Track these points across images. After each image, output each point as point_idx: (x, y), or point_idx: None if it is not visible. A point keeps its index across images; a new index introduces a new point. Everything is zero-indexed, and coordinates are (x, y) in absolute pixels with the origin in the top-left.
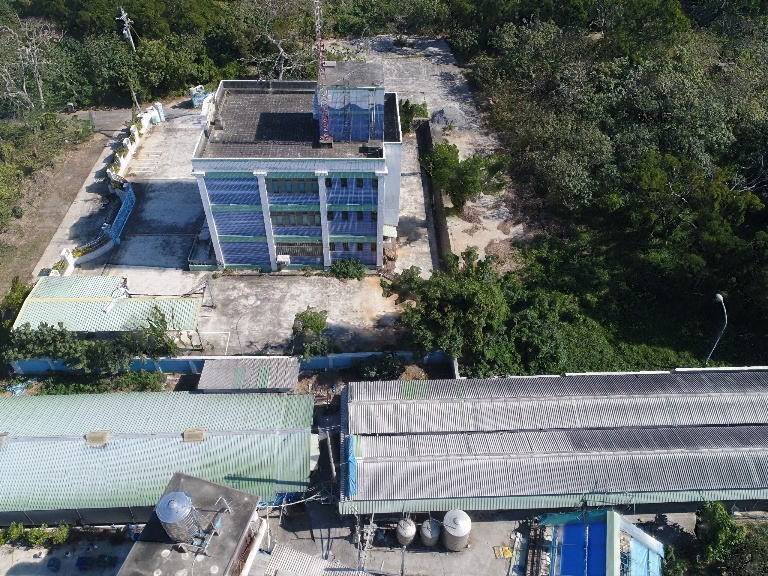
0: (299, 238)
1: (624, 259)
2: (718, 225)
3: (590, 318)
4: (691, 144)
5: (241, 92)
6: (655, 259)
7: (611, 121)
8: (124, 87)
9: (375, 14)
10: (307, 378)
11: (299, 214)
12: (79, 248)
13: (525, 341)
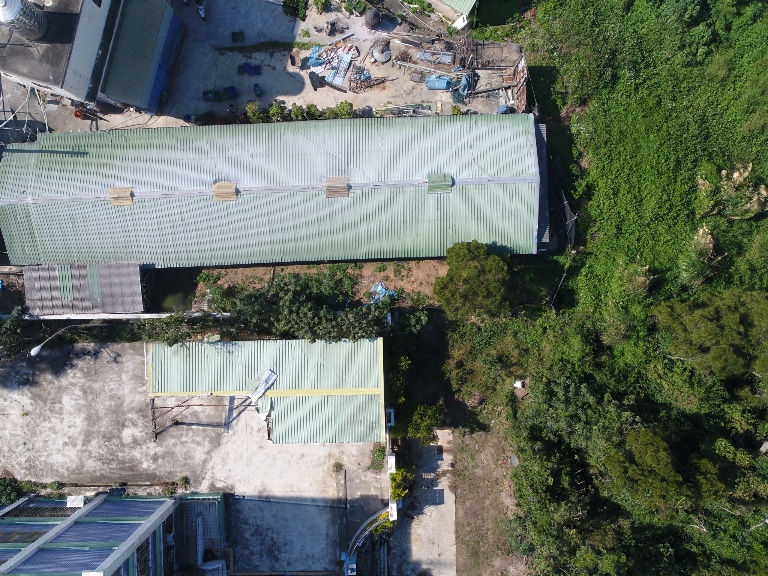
0: (29, 521)
1: None
2: None
3: None
4: None
5: None
6: None
7: None
8: None
9: None
10: None
11: None
12: None
13: None
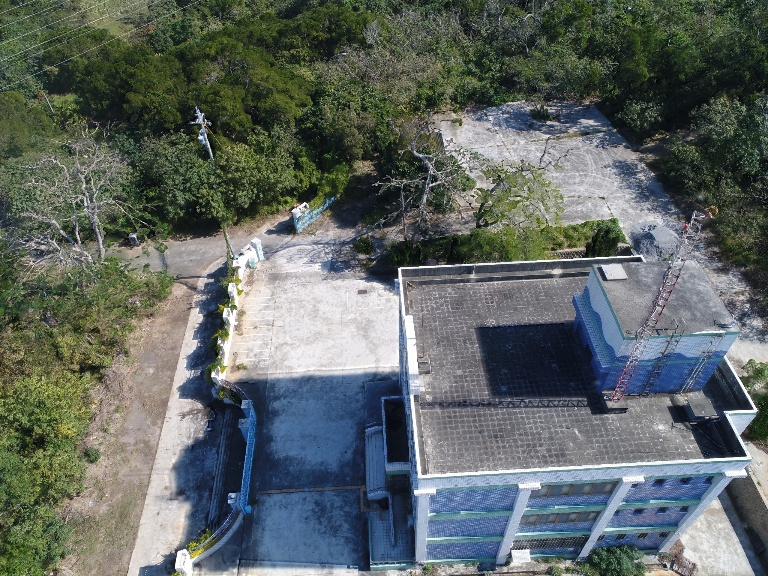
0: (554, 534)
1: None
2: None
3: None
4: None
5: (428, 282)
6: None
7: None
8: (204, 213)
9: (498, 74)
10: None
11: (566, 513)
12: (199, 545)
13: None
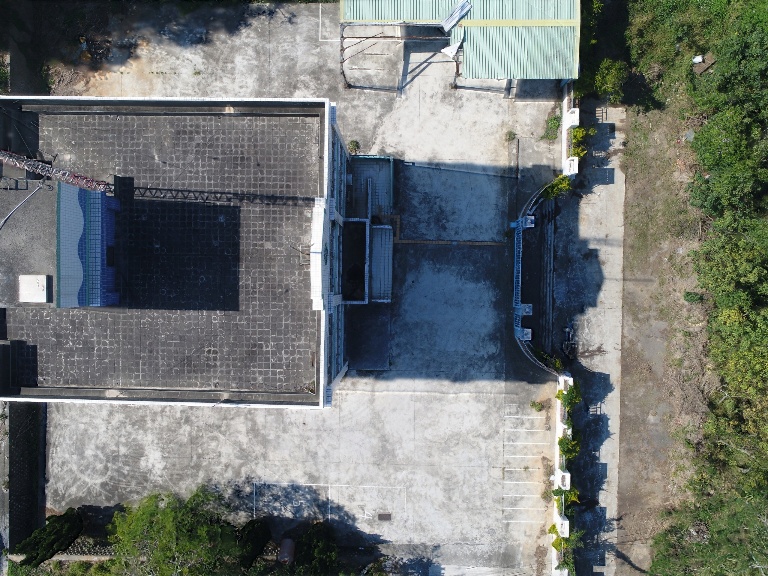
0: None
1: None
2: None
3: None
4: None
5: None
6: None
7: None
8: None
9: None
10: None
11: None
12: None
13: None
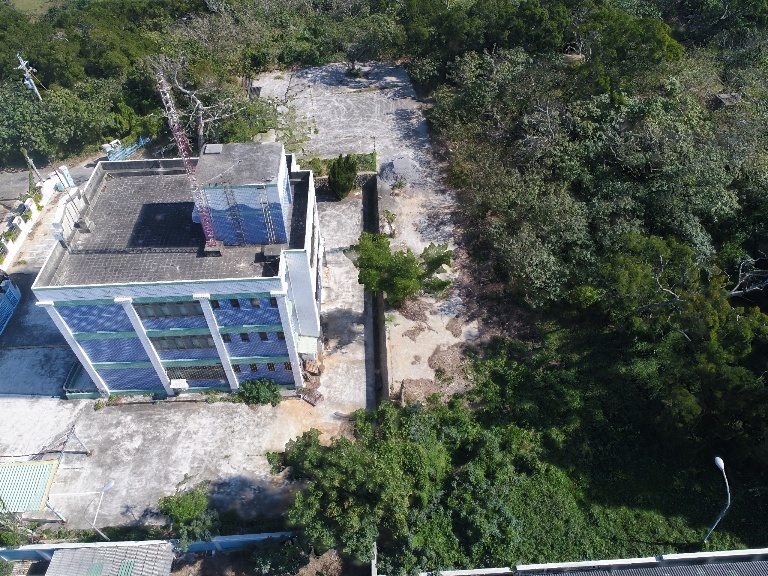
0: (193, 362)
1: (600, 375)
2: (717, 347)
3: (554, 467)
4: (683, 221)
5: (125, 174)
6: (640, 374)
7: (588, 178)
8: (28, 147)
9: None
10: (189, 566)
11: (186, 338)
12: None
13: (465, 517)
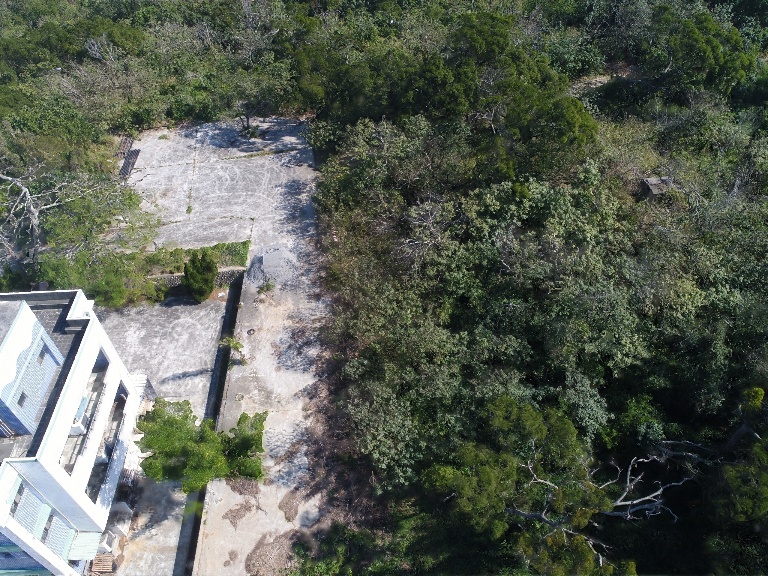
0: None
1: None
2: None
3: None
4: None
5: None
6: None
7: (477, 294)
8: None
9: None
10: None
11: None
12: None
13: None
